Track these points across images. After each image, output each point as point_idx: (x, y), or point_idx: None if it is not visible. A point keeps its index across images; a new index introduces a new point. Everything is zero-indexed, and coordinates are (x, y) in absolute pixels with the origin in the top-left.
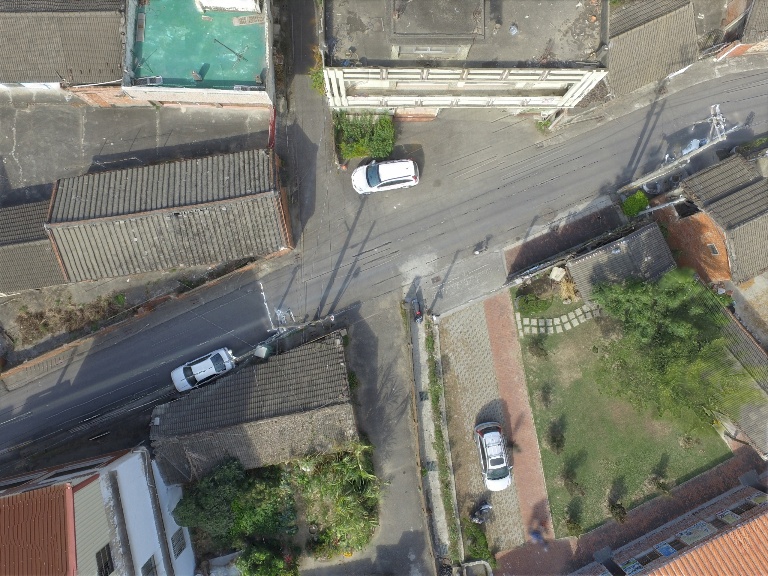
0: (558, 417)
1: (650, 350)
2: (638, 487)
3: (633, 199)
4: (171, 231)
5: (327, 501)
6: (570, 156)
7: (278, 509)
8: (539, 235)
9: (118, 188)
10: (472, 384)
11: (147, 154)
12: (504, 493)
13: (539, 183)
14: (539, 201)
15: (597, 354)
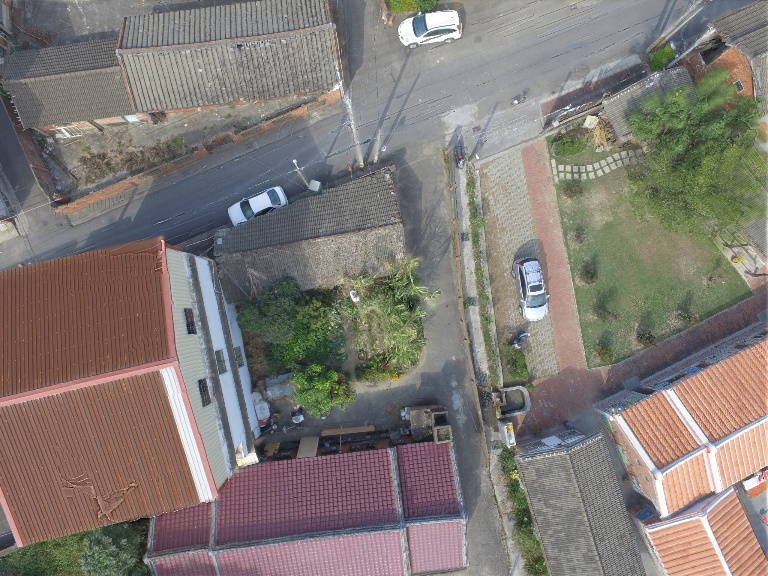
0: (591, 257)
1: (683, 163)
2: (664, 322)
3: (662, 53)
4: (234, 63)
5: (375, 331)
6: (602, 17)
7: (329, 337)
8: (573, 90)
9: (183, 24)
10: (510, 225)
11: (204, 5)
12: (540, 326)
13: (573, 42)
14: (573, 58)
15: (627, 199)
